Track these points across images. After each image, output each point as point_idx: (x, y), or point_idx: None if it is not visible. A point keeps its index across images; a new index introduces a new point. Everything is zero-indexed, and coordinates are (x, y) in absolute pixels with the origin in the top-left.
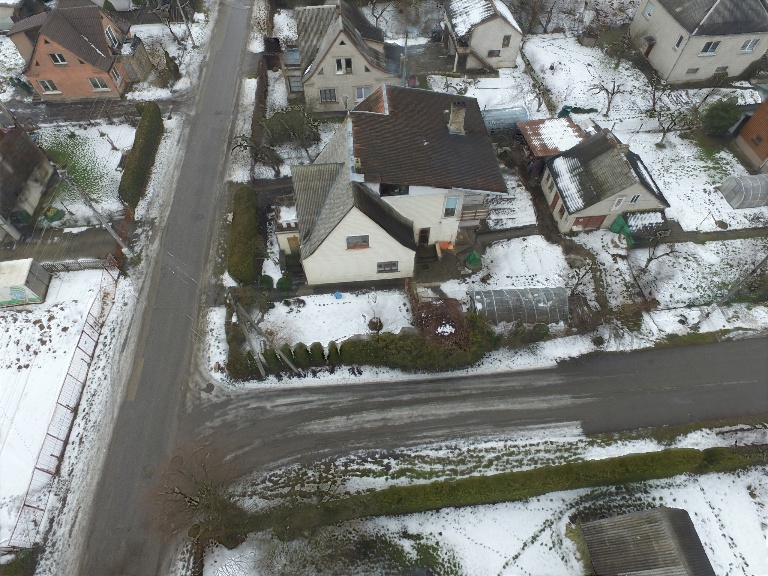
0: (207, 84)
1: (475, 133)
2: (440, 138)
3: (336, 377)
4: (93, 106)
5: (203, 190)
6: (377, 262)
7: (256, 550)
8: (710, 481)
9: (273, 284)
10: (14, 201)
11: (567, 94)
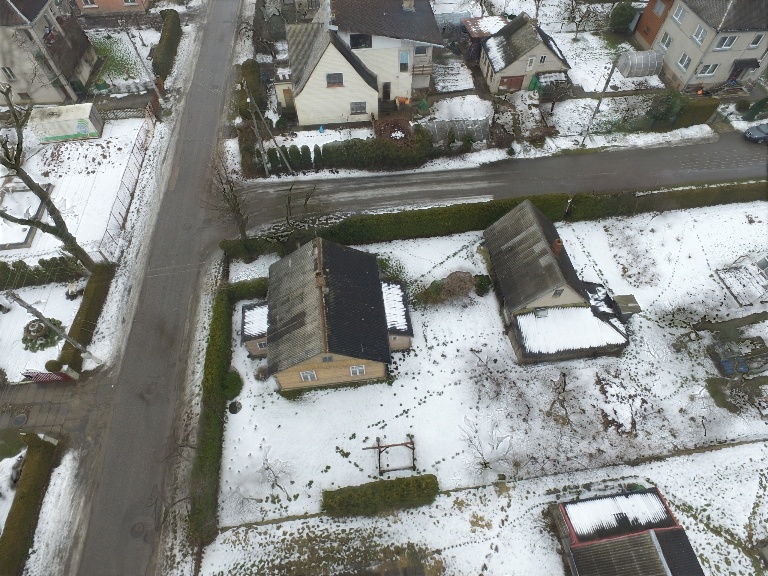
0: (215, 2)
1: (423, 11)
2: (396, 12)
3: (320, 175)
4: (123, 18)
5: (216, 70)
6: (350, 102)
7: (265, 263)
8: (579, 225)
9: (273, 125)
10: (73, 69)
11: (506, 6)
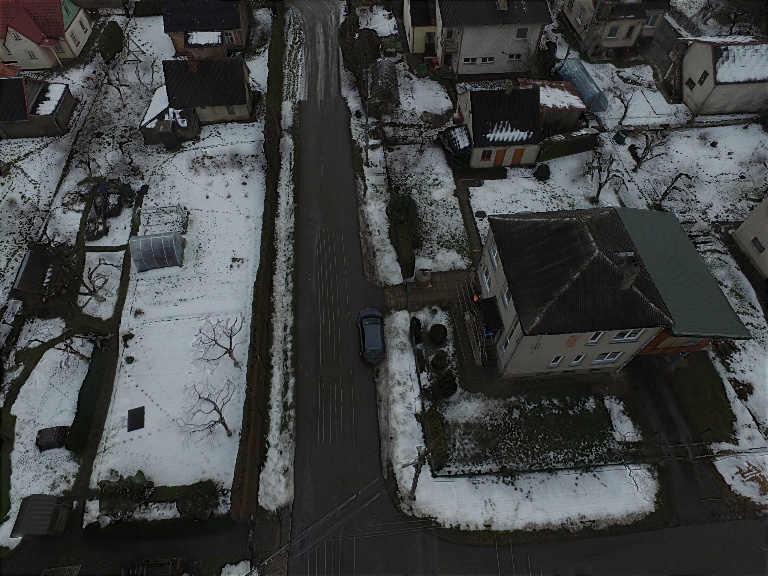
0: None
1: (503, 15)
2: None
3: None
4: None
5: None
6: None
7: None
8: None
9: None
10: None
11: None
